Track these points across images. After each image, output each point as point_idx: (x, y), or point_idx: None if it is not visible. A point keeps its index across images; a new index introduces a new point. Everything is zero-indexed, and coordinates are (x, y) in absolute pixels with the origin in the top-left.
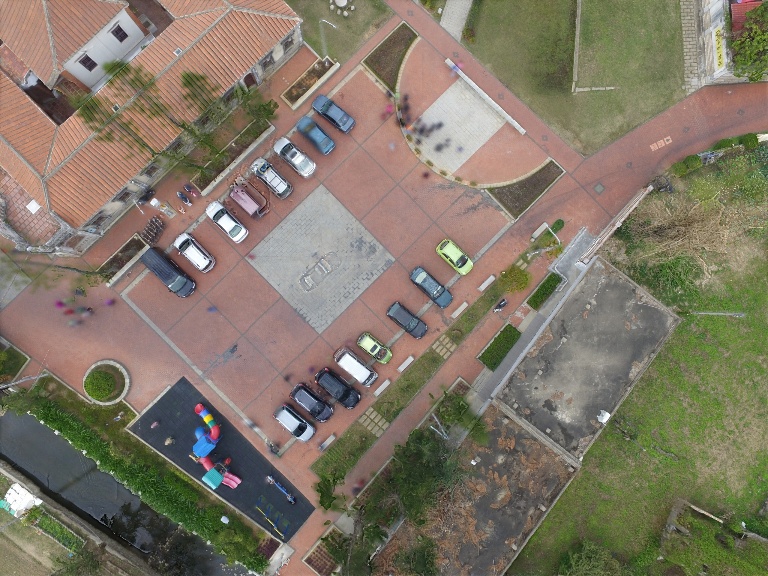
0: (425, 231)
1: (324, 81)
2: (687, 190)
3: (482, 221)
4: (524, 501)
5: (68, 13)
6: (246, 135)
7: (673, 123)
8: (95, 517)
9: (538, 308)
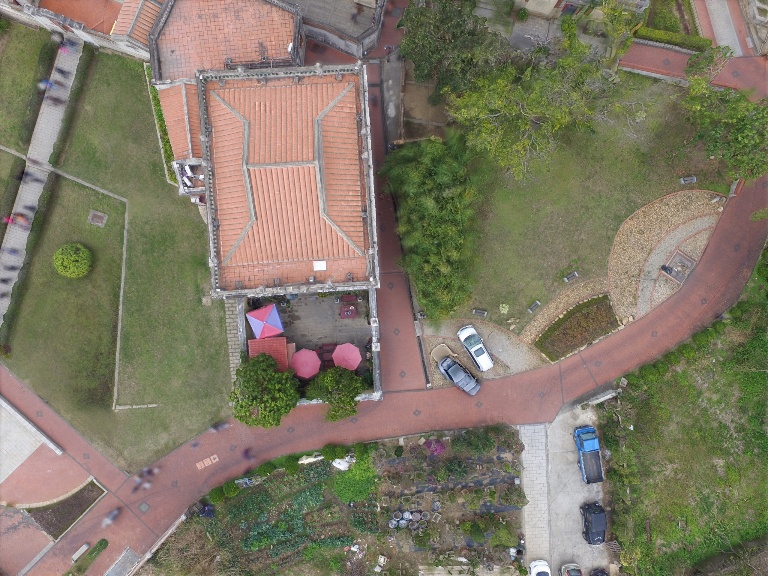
0: None
1: None
2: (228, 514)
3: (23, 541)
4: None
5: None
6: None
7: (220, 441)
8: None
9: None
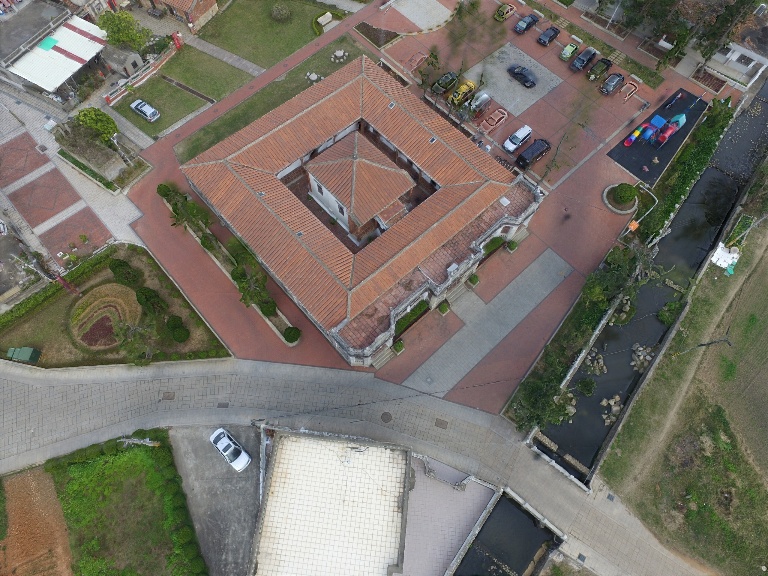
0: (489, 28)
1: None
2: None
3: (481, 2)
4: None
5: None
6: None
7: None
8: None
9: None
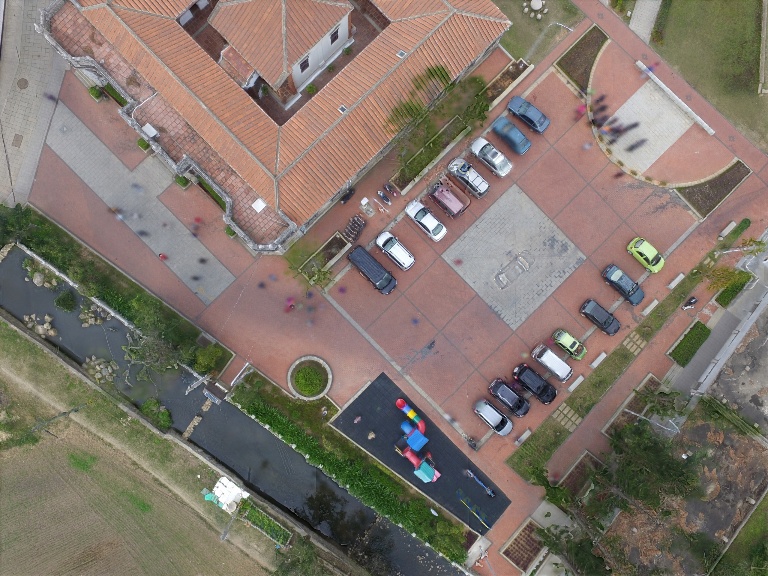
0: (615, 230)
1: (518, 83)
2: None
3: (670, 220)
4: (733, 494)
5: (302, 16)
6: (443, 136)
7: None
8: (291, 510)
9: (726, 305)
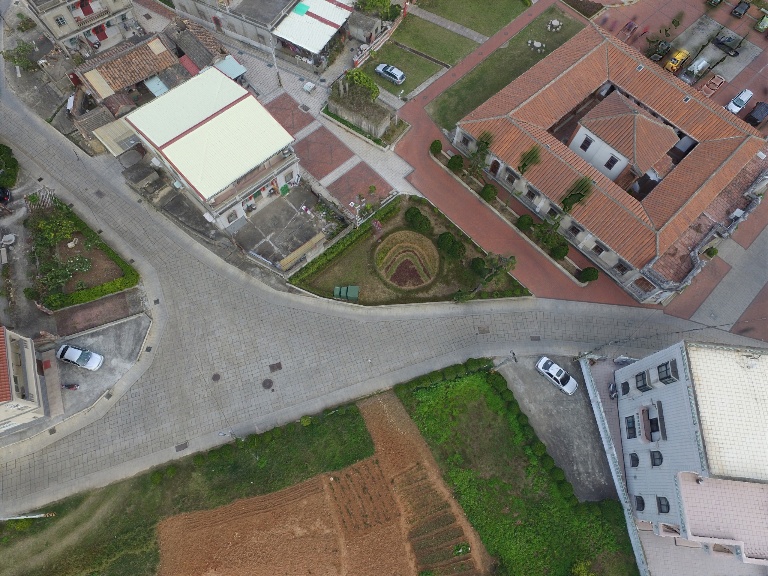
0: (683, 1)
1: None
2: None
3: None
4: None
5: None
6: None
7: None
8: None
9: None
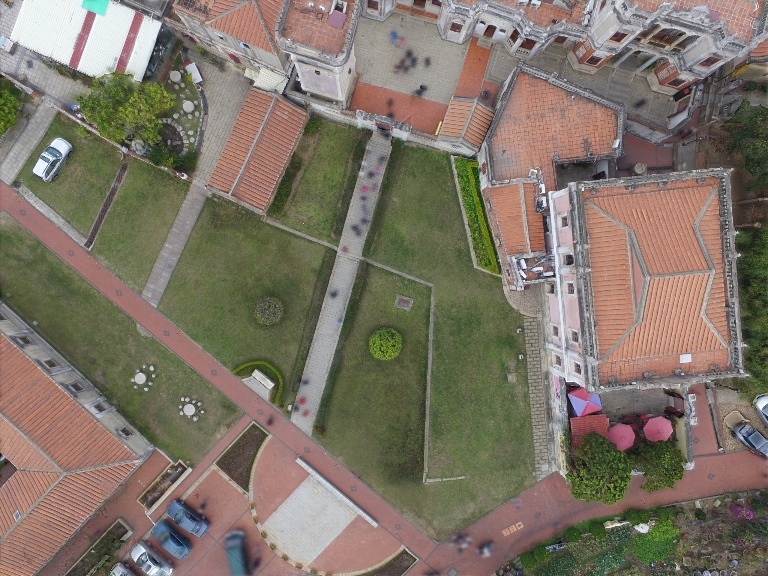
0: None
1: None
2: None
3: None
4: None
5: None
6: (105, 540)
7: (524, 509)
8: None
9: None
